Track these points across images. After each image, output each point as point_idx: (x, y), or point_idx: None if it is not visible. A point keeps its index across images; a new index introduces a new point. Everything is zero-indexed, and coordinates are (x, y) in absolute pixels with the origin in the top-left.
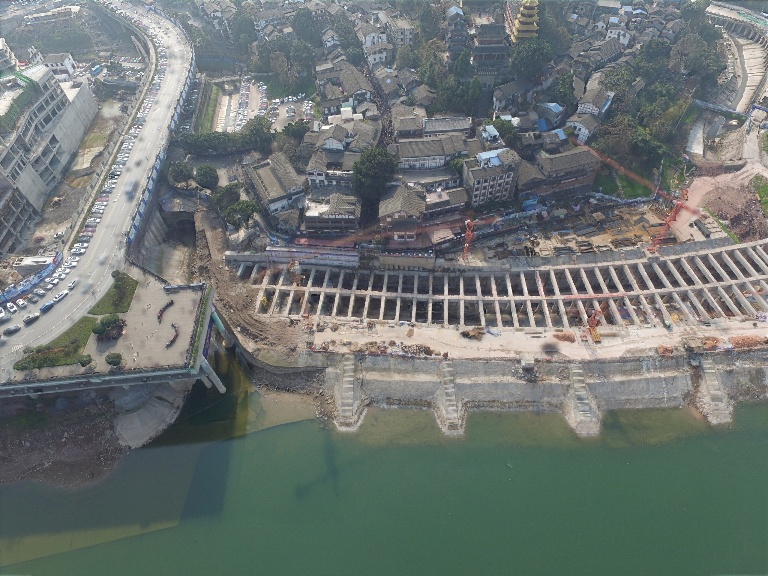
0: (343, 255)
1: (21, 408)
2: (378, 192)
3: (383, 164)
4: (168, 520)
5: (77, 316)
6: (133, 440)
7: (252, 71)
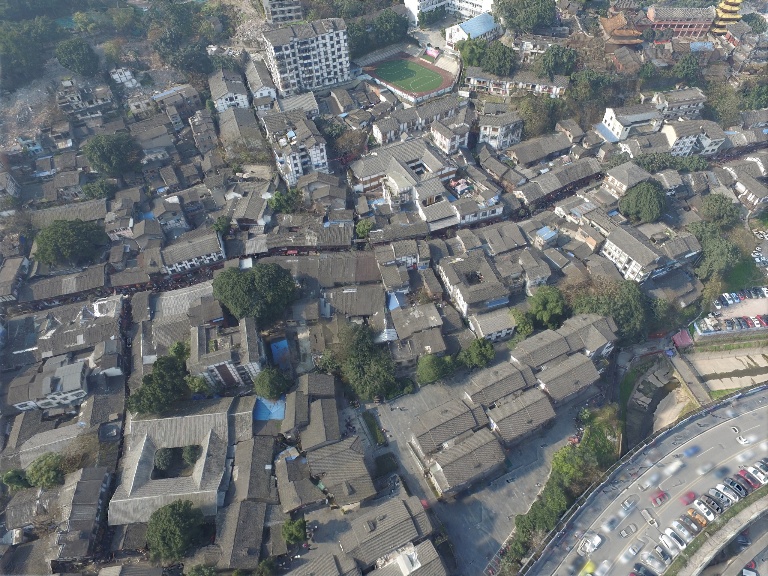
0: None
1: None
2: None
3: None
4: None
5: None
6: None
7: None
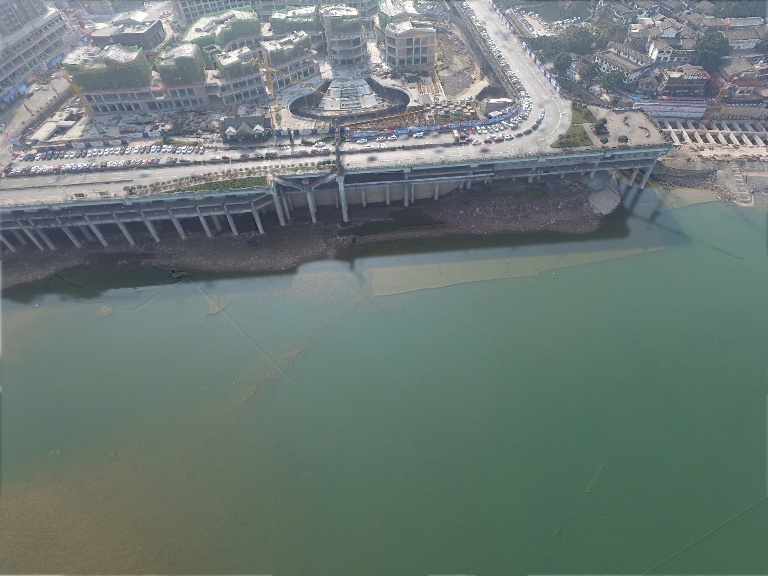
0: (695, 106)
1: (526, 187)
2: (715, 63)
3: (724, 41)
4: (658, 246)
5: (566, 125)
6: (603, 209)
7: (521, 4)
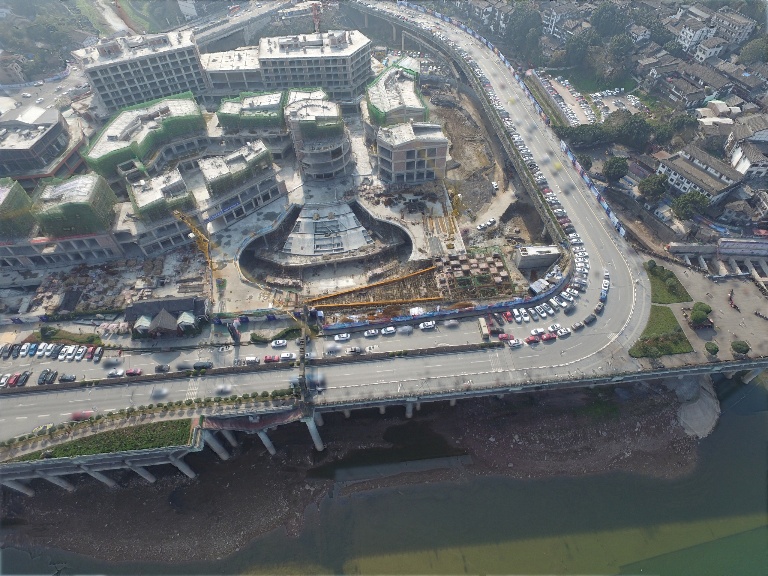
0: None
1: (586, 398)
2: None
3: None
4: None
5: (644, 305)
6: (699, 430)
7: (546, 66)
